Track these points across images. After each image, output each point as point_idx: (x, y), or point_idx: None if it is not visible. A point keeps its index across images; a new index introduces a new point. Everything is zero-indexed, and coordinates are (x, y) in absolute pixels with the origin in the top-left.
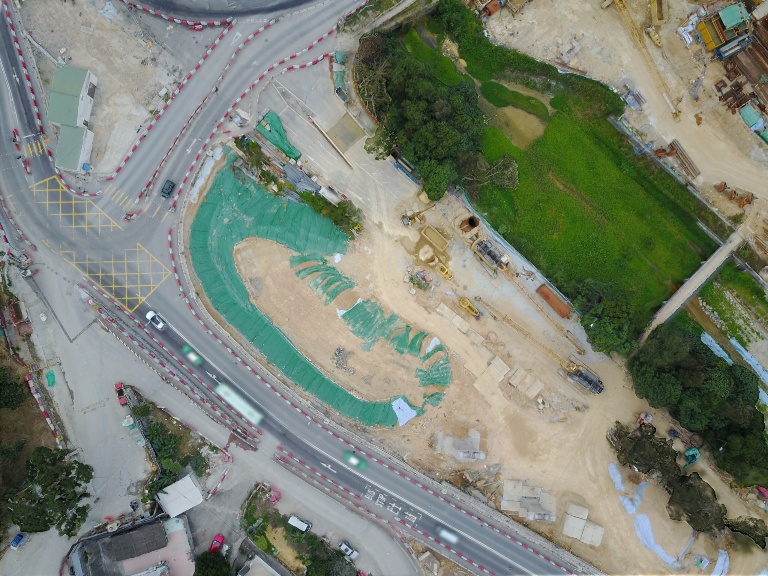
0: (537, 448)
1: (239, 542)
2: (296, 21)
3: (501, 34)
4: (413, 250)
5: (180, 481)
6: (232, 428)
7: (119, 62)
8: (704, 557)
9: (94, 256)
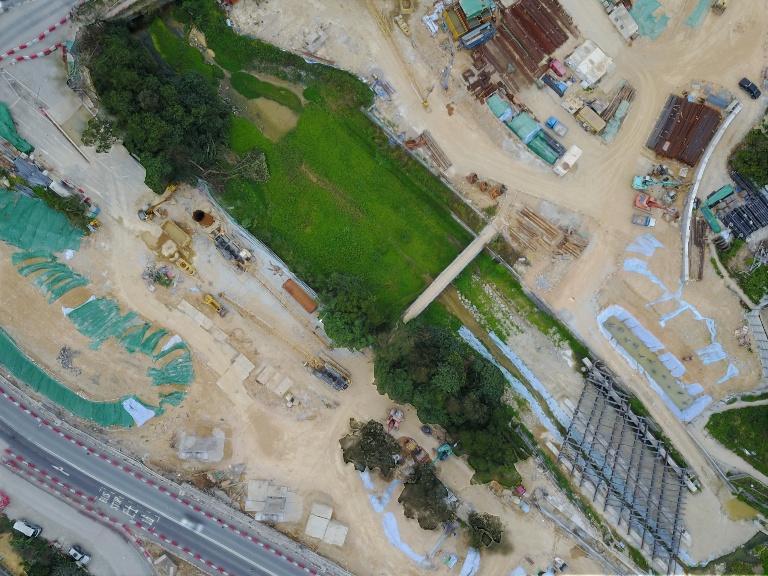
0: (283, 447)
1: None
2: (27, 10)
3: (245, 23)
4: (155, 246)
5: None
6: None
7: None
8: (453, 555)
9: None
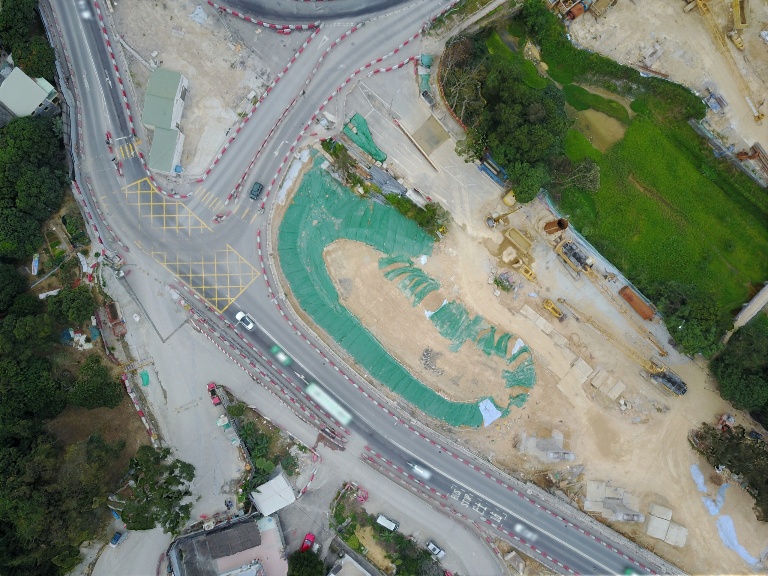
0: (620, 449)
1: (329, 541)
2: (382, 25)
3: (584, 38)
4: (496, 252)
5: (273, 480)
6: (321, 428)
7: (209, 65)
8: None
9: (185, 257)
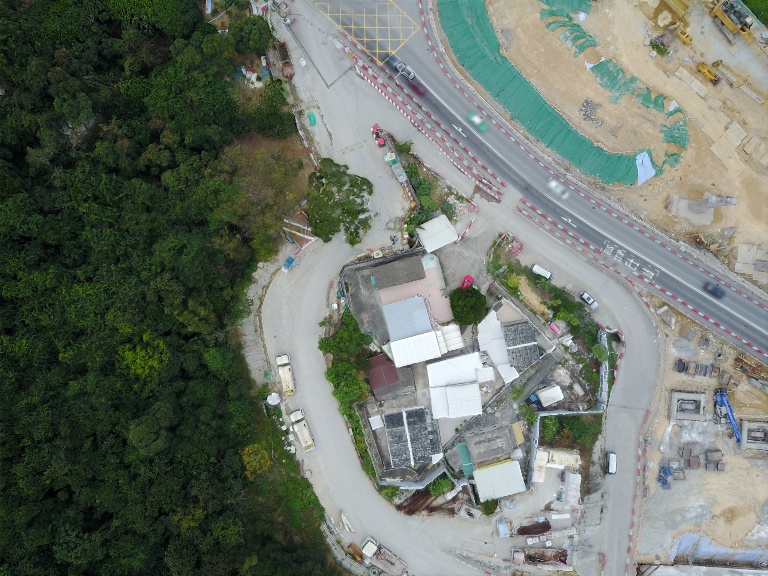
0: None
1: (487, 285)
2: None
3: None
4: (651, 16)
5: (436, 218)
6: (478, 178)
7: None
8: None
9: (347, 9)
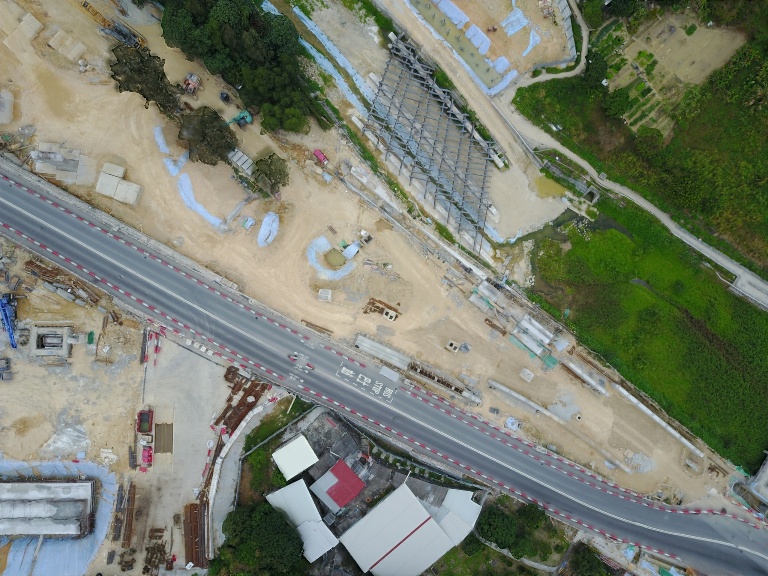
0: (75, 109)
1: None
2: None
3: None
4: None
5: None
6: None
7: None
8: (250, 217)
9: None
